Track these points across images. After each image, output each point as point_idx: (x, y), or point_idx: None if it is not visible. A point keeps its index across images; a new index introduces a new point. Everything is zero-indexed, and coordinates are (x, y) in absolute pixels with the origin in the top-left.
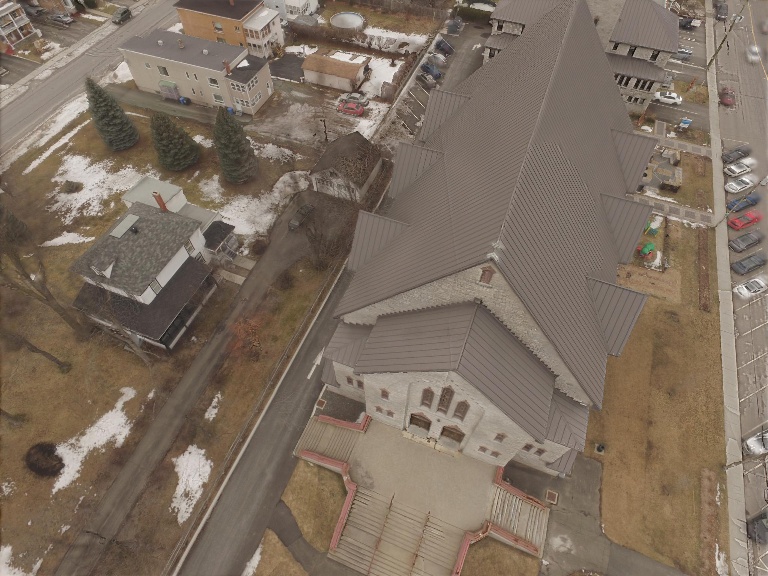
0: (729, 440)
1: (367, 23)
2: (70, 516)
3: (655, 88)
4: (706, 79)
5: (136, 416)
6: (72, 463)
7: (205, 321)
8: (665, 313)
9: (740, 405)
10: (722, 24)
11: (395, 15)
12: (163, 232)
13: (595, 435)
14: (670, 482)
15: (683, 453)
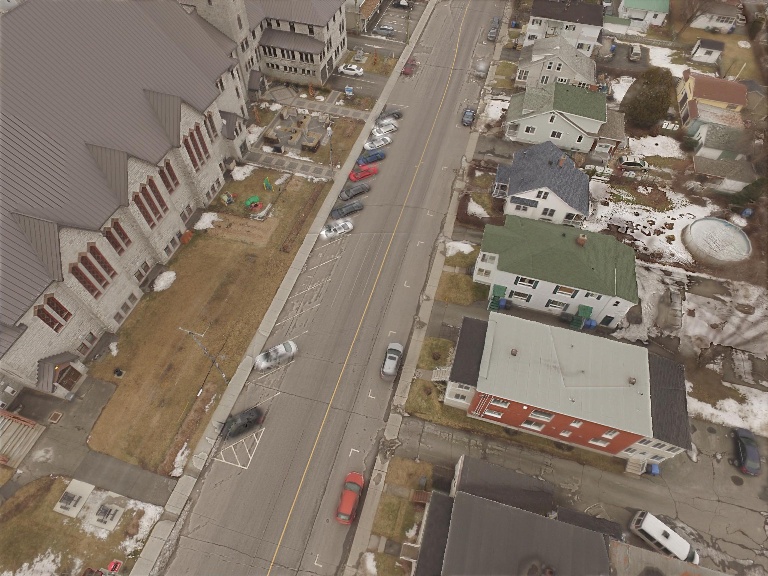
0: (246, 358)
1: None
2: None
3: (316, 60)
4: (401, 52)
5: None
6: None
7: None
8: (246, 256)
9: (274, 328)
10: (443, 3)
11: None
12: None
13: (123, 363)
14: (171, 396)
15: (196, 371)
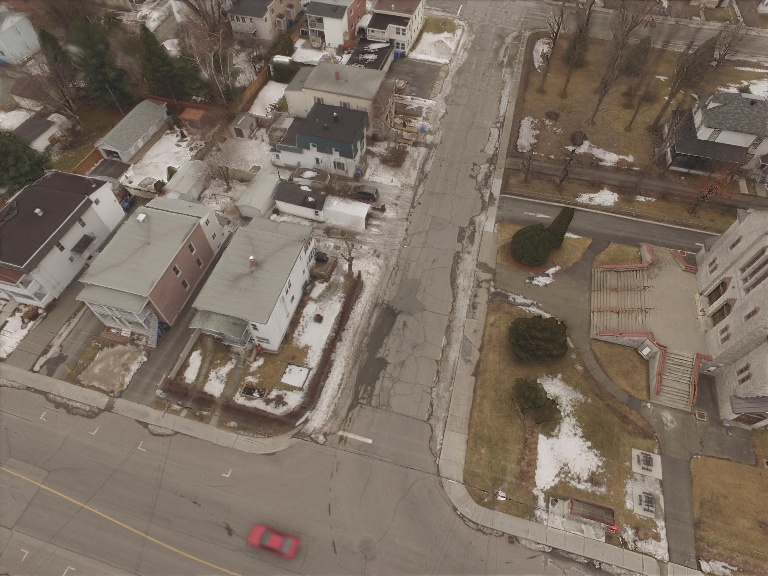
0: None
1: None
2: (558, 157)
3: None
4: None
5: (619, 166)
6: (582, 149)
7: (699, 180)
8: None
9: None
10: None
11: None
12: (761, 119)
13: None
14: None
15: None
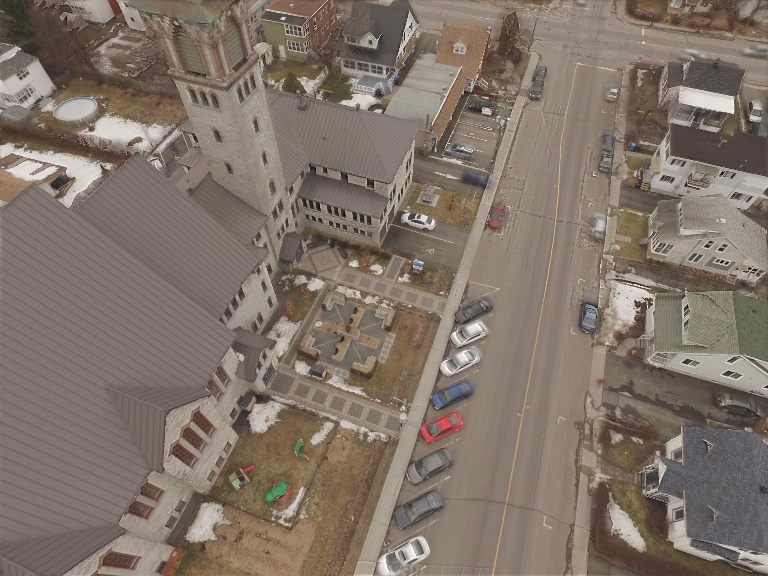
0: None
1: (106, 110)
2: None
3: (375, 222)
4: (484, 187)
5: None
6: None
7: None
8: None
9: None
10: (534, 105)
11: (146, 98)
12: None
13: None
14: None
15: None
